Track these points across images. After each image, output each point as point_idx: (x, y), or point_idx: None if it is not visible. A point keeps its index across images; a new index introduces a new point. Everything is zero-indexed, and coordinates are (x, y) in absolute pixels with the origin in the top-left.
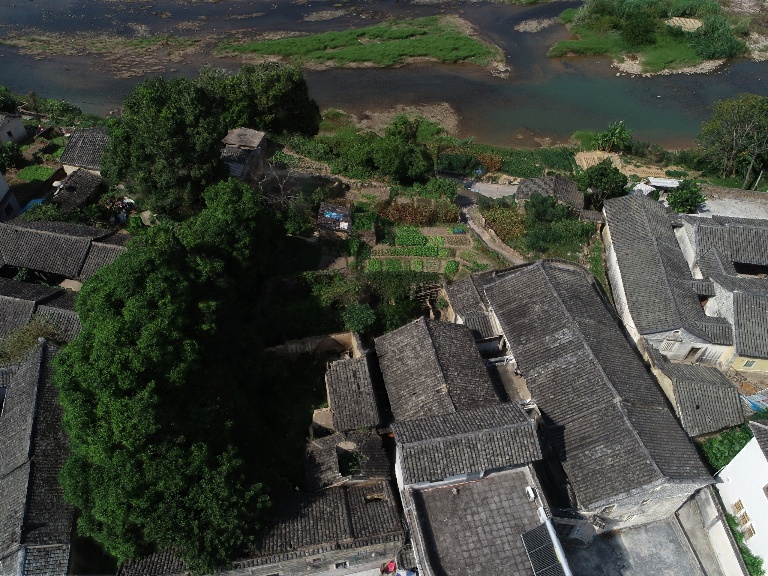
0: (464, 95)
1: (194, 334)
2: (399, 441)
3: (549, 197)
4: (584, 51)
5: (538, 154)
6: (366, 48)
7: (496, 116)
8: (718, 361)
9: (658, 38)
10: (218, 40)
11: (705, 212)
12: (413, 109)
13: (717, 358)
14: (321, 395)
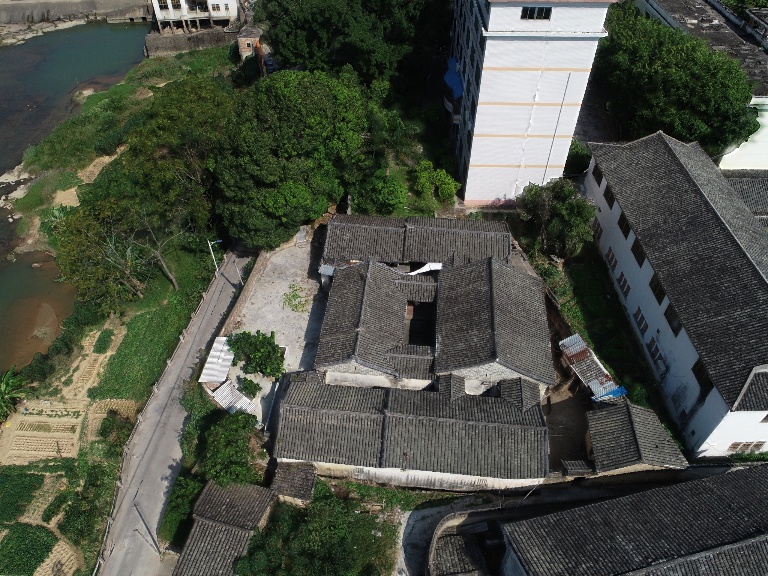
0: None
1: None
2: None
3: (254, 540)
4: None
5: None
6: None
7: None
8: None
9: None
10: None
11: None
12: None
13: None
14: None
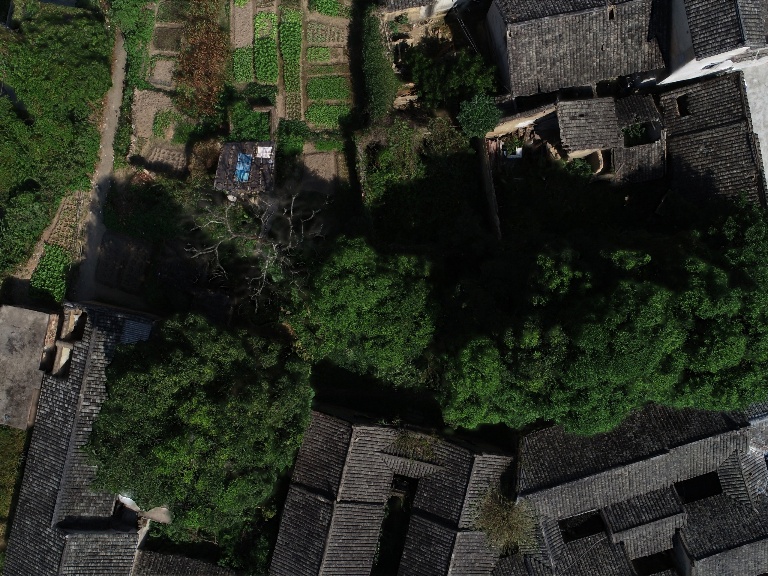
0: None
1: (643, 276)
2: (736, 45)
3: None
4: None
5: None
6: None
7: None
8: None
9: None
10: None
11: None
12: None
13: None
14: (551, 171)
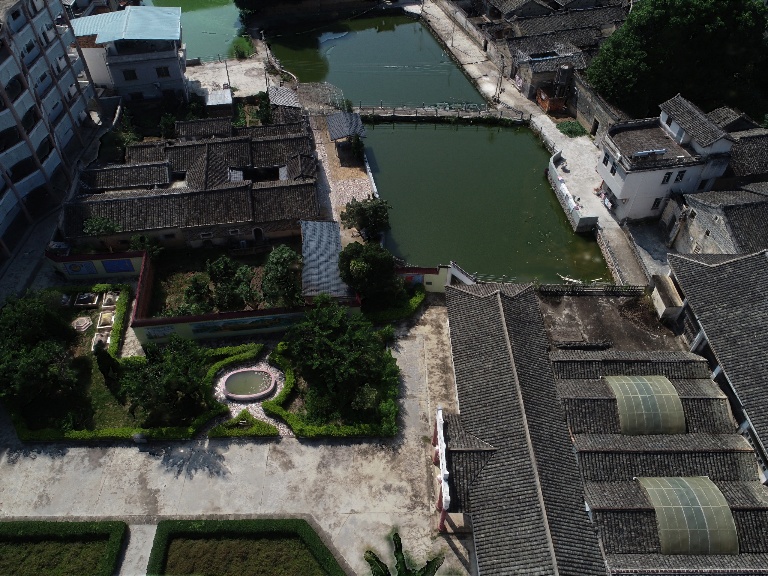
0: None
1: None
2: None
3: None
4: None
5: None
6: None
7: None
8: None
9: None
10: None
11: None
12: None
13: None
14: None
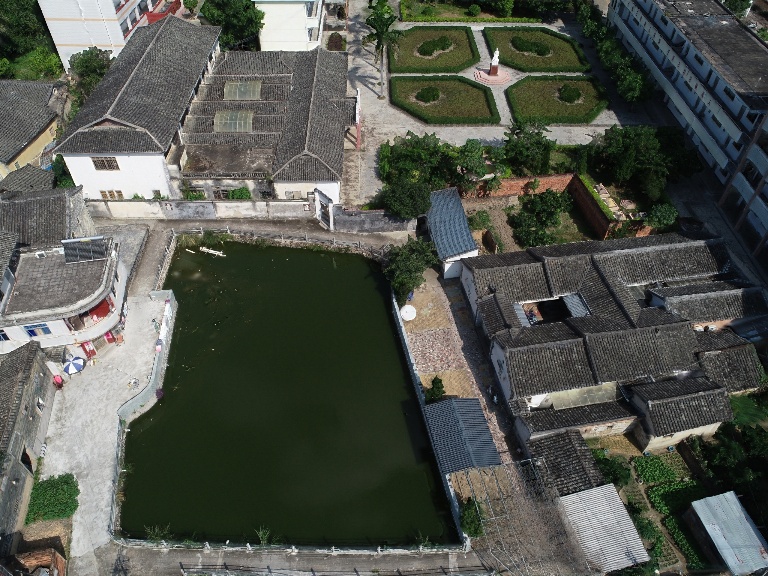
0: None
1: None
2: None
3: None
4: None
5: None
6: None
7: None
8: None
9: None
10: None
11: None
12: None
13: None
14: None
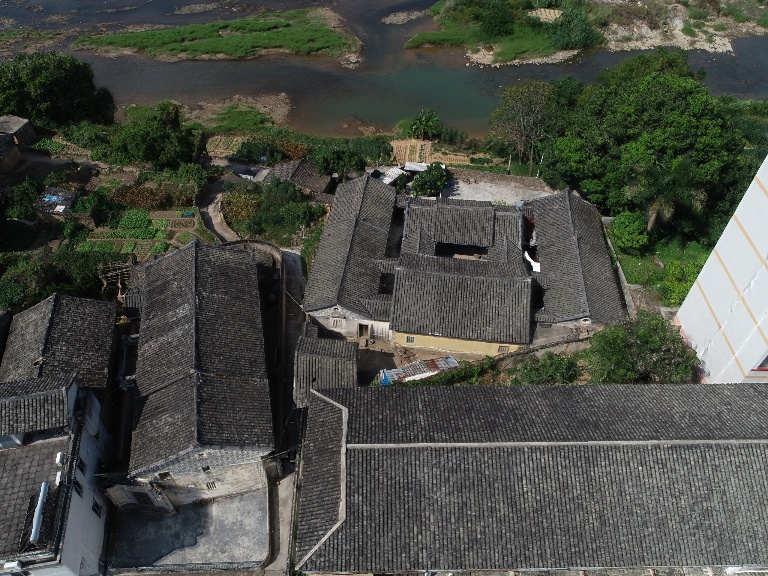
0: (306, 86)
1: None
2: None
3: (286, 181)
4: (440, 42)
5: (352, 142)
6: (222, 40)
7: (330, 106)
8: (390, 338)
9: (516, 29)
10: (80, 33)
11: (455, 196)
12: (249, 99)
13: (387, 335)
14: None
